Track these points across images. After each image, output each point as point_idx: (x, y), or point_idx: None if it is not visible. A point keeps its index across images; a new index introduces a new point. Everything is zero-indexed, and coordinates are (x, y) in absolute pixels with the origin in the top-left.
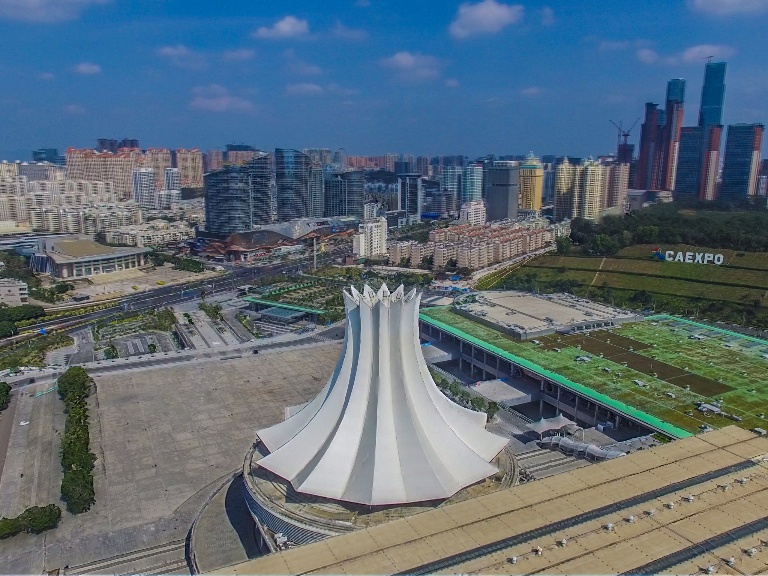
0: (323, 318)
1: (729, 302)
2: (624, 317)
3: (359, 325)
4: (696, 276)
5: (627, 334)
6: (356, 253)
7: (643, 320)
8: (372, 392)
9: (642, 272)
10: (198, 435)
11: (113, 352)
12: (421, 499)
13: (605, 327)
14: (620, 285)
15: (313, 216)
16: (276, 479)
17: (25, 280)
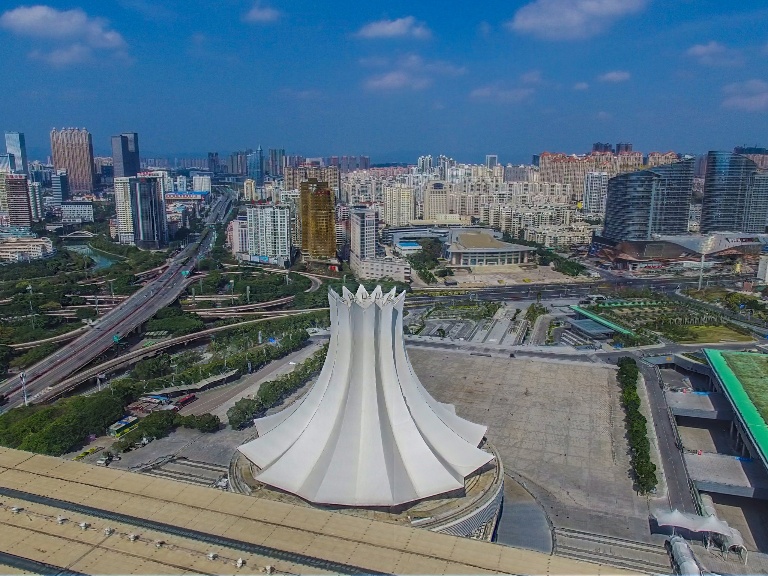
0: (617, 339)
1: None
2: None
3: None
4: None
5: None
6: (760, 278)
7: None
8: None
9: None
10: None
11: (411, 329)
12: (302, 495)
13: None
14: None
15: (748, 230)
16: None
17: (427, 263)
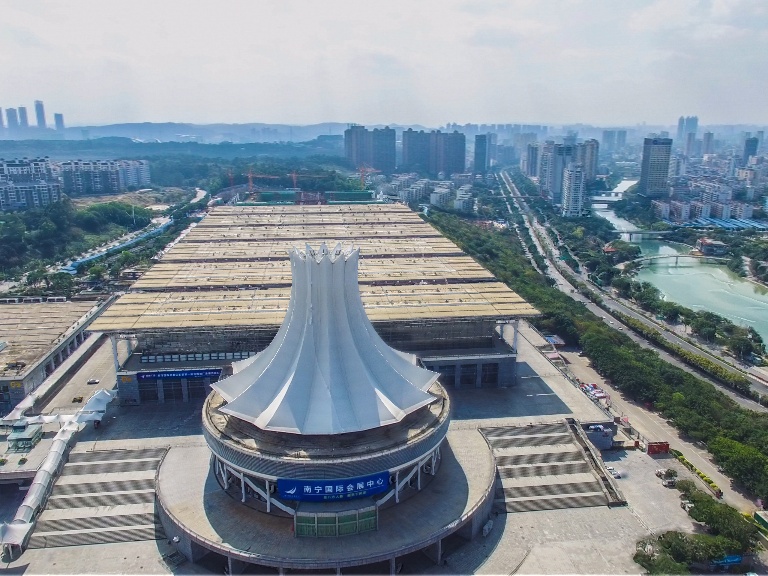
0: None
1: None
2: None
3: None
4: None
5: None
6: None
7: None
8: None
9: None
10: None
11: None
12: None
13: None
14: None
15: None
16: None
17: None
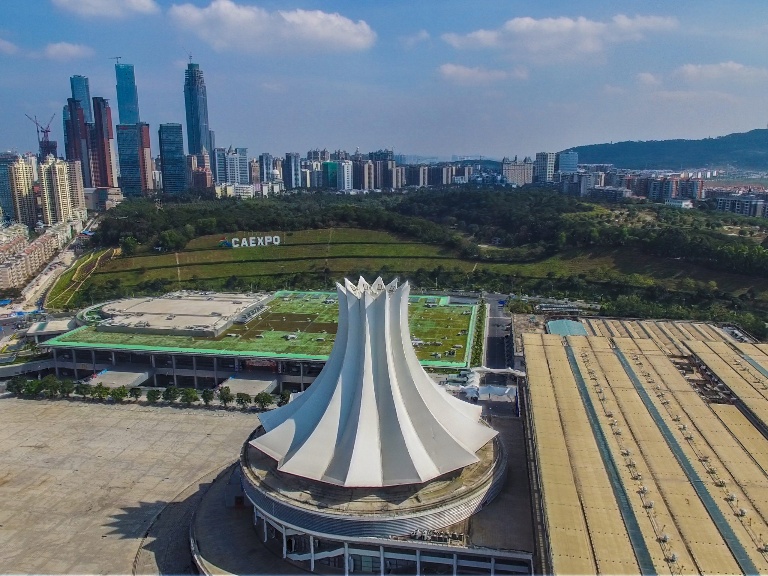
0: None
1: (306, 273)
2: (264, 299)
3: (376, 318)
4: (266, 257)
5: (285, 311)
6: None
7: (275, 298)
8: (402, 377)
9: (219, 260)
10: (1, 566)
11: None
12: (483, 444)
13: (263, 310)
14: (206, 275)
15: None
16: (354, 497)
17: None
